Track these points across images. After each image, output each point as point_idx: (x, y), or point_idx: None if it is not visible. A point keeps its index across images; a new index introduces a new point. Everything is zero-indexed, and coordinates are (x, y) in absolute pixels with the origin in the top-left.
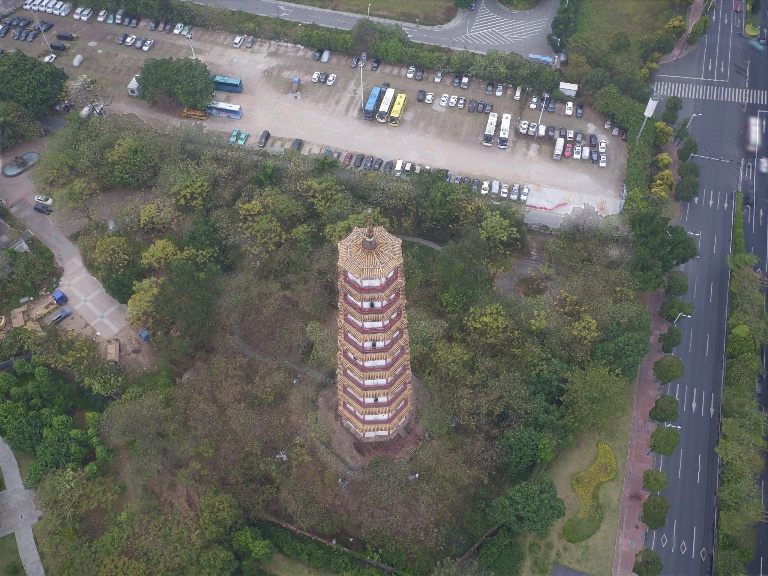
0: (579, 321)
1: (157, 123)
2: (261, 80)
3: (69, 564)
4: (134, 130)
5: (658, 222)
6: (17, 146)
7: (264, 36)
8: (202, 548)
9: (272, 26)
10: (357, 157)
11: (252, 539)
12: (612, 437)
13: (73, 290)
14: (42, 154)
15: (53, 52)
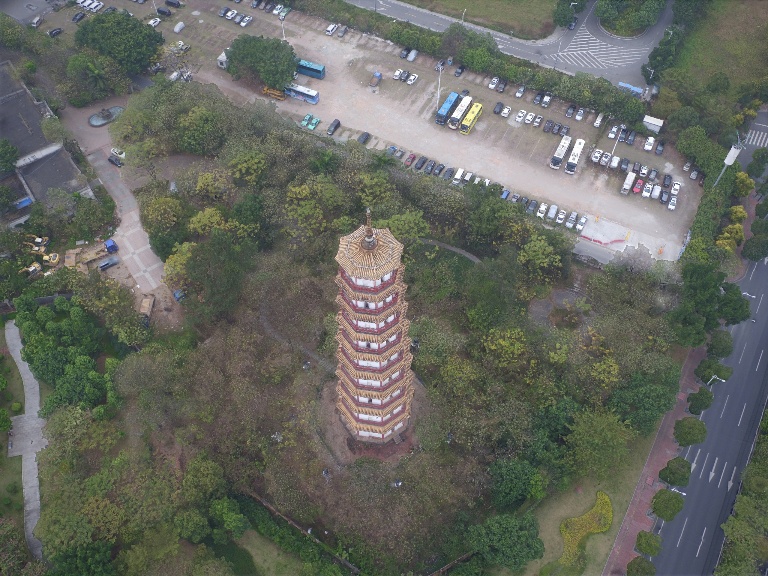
0: (601, 363)
1: (237, 97)
2: (344, 70)
3: (59, 495)
4: (212, 100)
5: (712, 276)
6: (107, 99)
7: (357, 27)
8: (179, 508)
9: (366, 19)
10: (420, 159)
11: (228, 510)
12: (614, 489)
13: (125, 241)
14: (123, 110)
15: (159, 16)
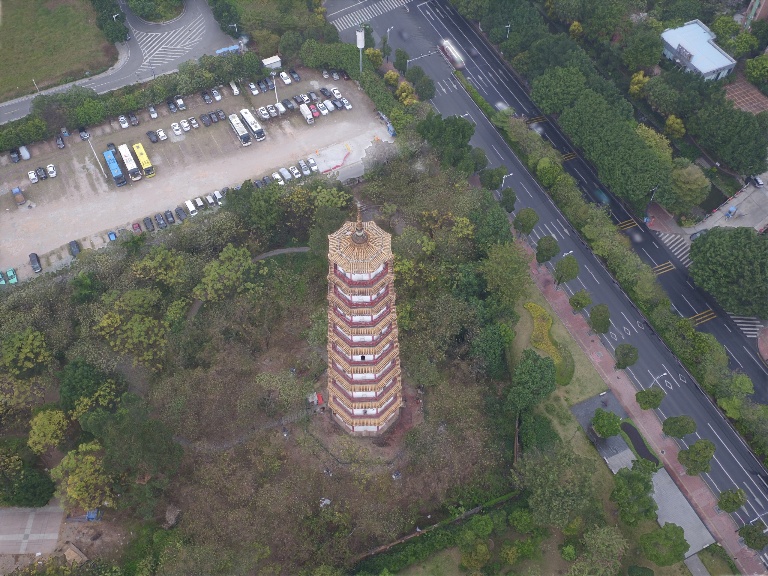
0: None
1: None
2: None
3: None
4: None
5: (438, 121)
6: None
7: None
8: None
9: None
10: (145, 222)
11: None
12: (528, 295)
13: None
14: None
15: None
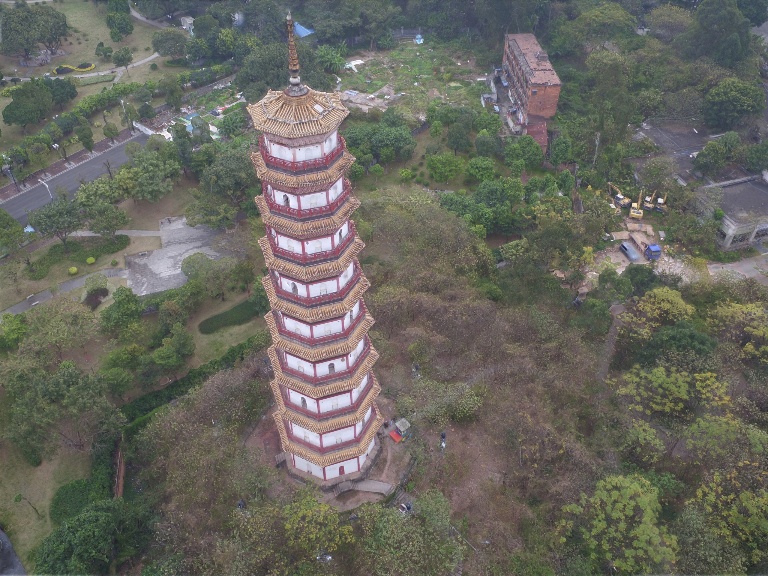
0: None
1: None
2: None
3: None
4: None
5: None
6: None
7: None
8: None
9: None
10: None
11: None
12: None
13: None
14: None
15: None
